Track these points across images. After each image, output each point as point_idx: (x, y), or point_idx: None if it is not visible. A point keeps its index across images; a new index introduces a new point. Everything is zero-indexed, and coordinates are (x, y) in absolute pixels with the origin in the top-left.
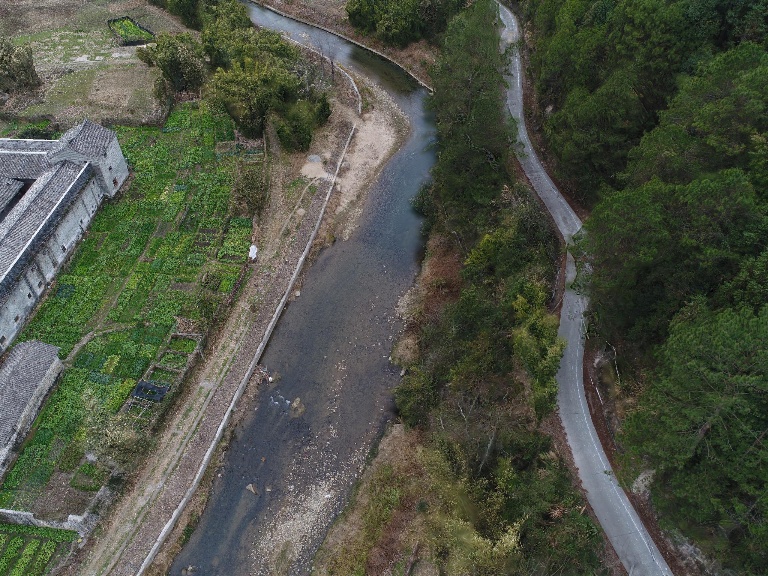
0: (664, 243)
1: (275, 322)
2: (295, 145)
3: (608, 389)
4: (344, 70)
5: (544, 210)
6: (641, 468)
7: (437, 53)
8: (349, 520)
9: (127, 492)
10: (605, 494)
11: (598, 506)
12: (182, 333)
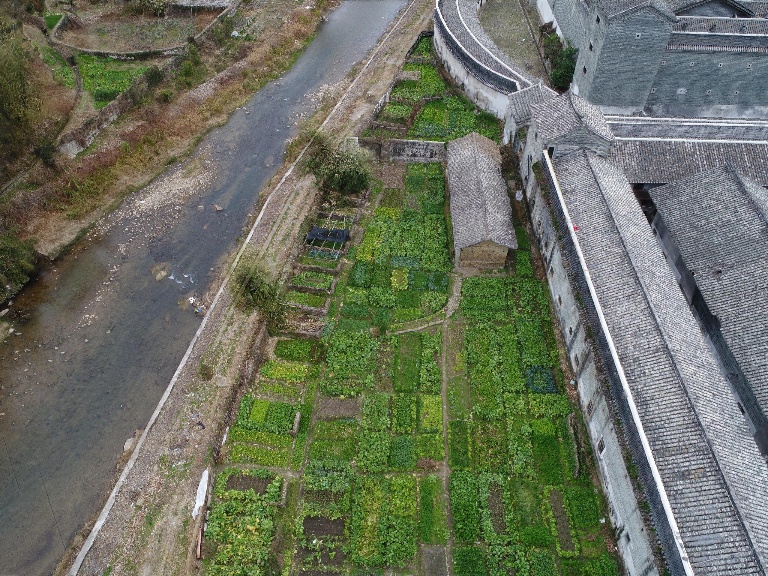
0: None
1: None
2: None
3: None
4: None
5: None
6: None
7: None
8: None
9: None
10: None
11: None
12: None
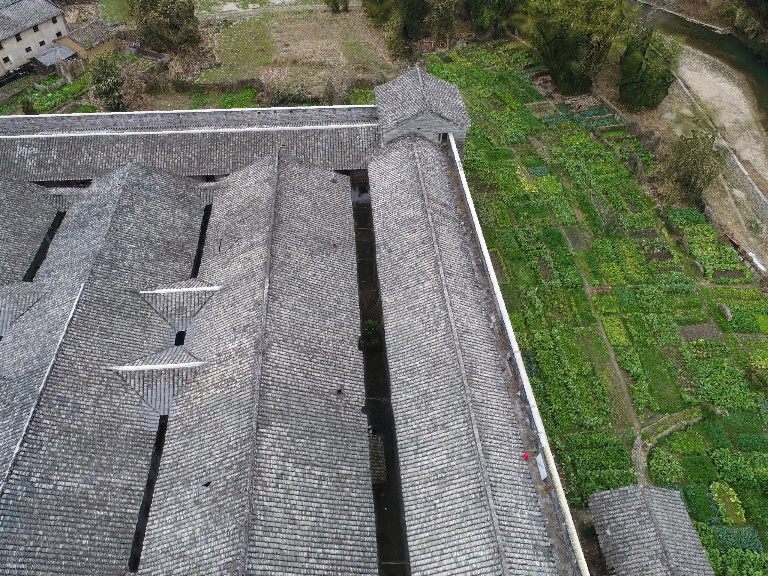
0: None
1: None
2: None
3: None
4: None
5: None
6: None
7: None
8: None
9: None
10: None
11: None
12: None
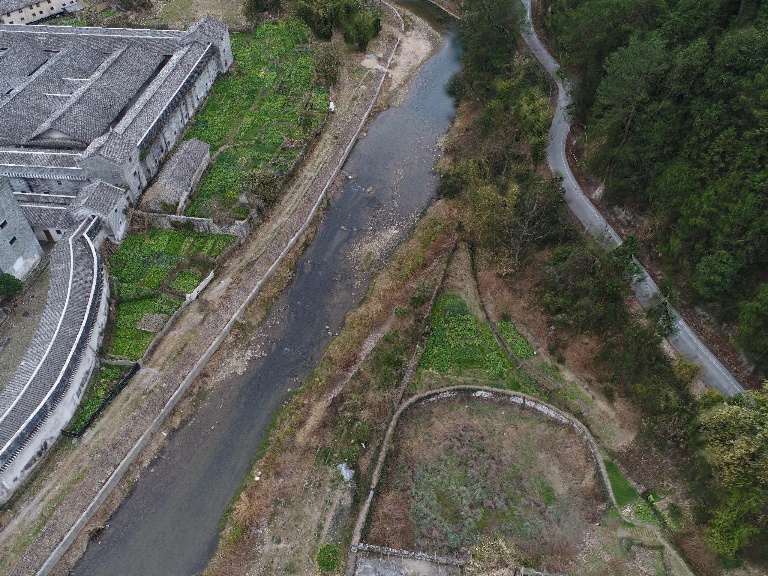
0: (611, 31)
1: (350, 148)
2: (355, 48)
3: (581, 152)
4: (388, 4)
5: (544, 70)
6: (598, 184)
7: None
8: (410, 242)
9: (265, 221)
10: (575, 198)
11: (570, 202)
12: (289, 146)
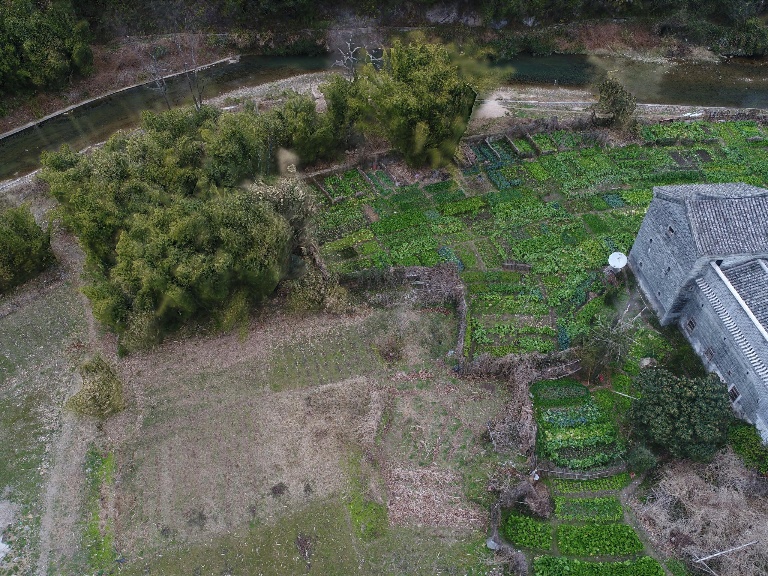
0: None
1: None
2: None
3: None
4: None
5: None
6: None
7: (137, 38)
8: None
9: None
10: None
11: None
12: None
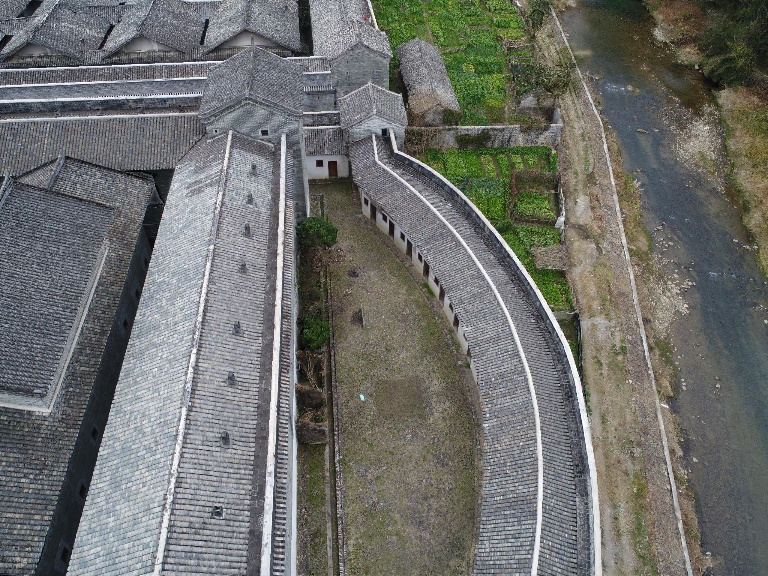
0: None
1: None
2: None
3: None
4: None
5: None
6: None
7: None
8: (736, 136)
9: None
10: None
11: None
12: (513, 46)
